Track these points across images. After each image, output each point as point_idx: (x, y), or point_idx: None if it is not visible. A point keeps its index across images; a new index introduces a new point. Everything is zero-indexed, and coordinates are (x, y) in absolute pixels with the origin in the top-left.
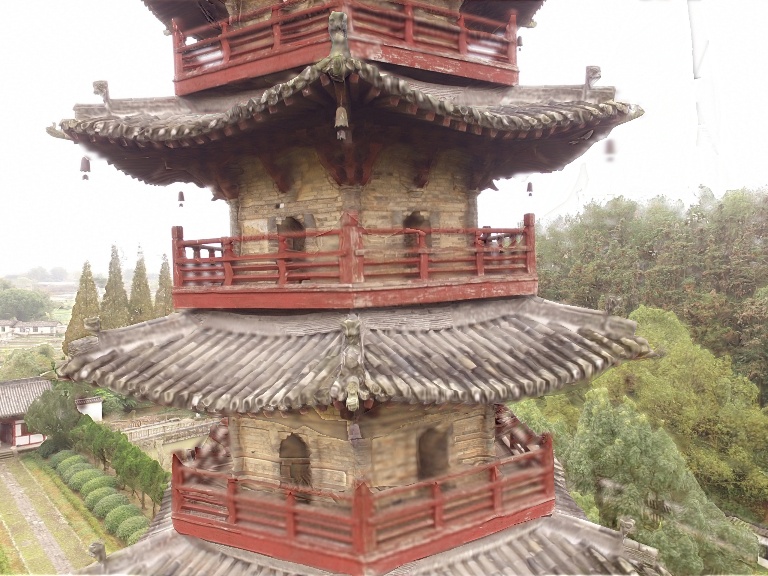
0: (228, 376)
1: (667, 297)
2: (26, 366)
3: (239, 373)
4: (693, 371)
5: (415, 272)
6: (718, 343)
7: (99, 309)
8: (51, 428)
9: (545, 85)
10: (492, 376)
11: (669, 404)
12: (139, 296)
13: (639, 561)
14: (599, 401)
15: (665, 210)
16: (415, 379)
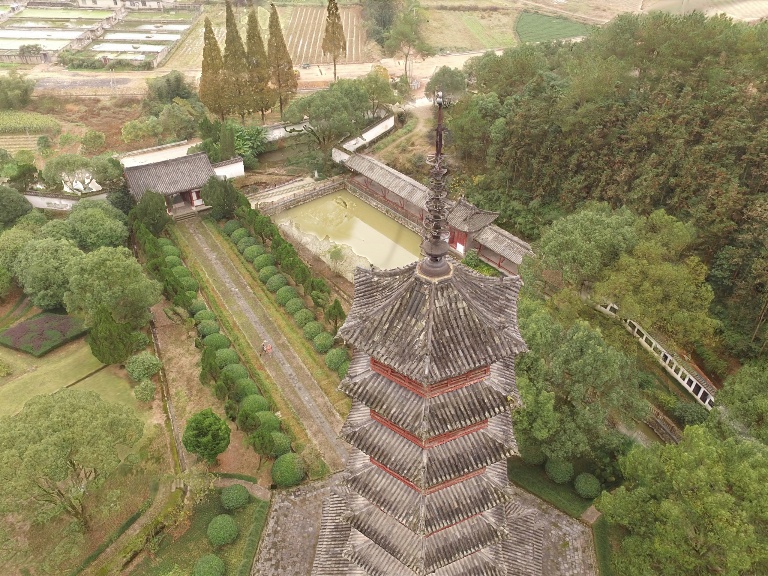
0: (390, 499)
1: (704, 171)
2: (176, 117)
3: (393, 499)
4: (666, 288)
5: (444, 482)
6: (719, 233)
7: (223, 62)
8: (221, 207)
9: (495, 433)
10: (461, 512)
11: (635, 318)
12: (254, 47)
13: (503, 533)
14: (580, 330)
15: (760, 41)
16: (438, 522)
